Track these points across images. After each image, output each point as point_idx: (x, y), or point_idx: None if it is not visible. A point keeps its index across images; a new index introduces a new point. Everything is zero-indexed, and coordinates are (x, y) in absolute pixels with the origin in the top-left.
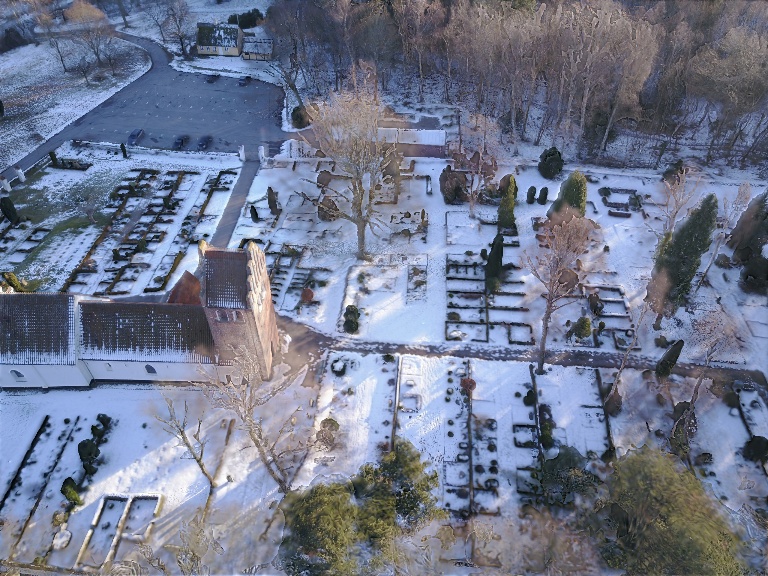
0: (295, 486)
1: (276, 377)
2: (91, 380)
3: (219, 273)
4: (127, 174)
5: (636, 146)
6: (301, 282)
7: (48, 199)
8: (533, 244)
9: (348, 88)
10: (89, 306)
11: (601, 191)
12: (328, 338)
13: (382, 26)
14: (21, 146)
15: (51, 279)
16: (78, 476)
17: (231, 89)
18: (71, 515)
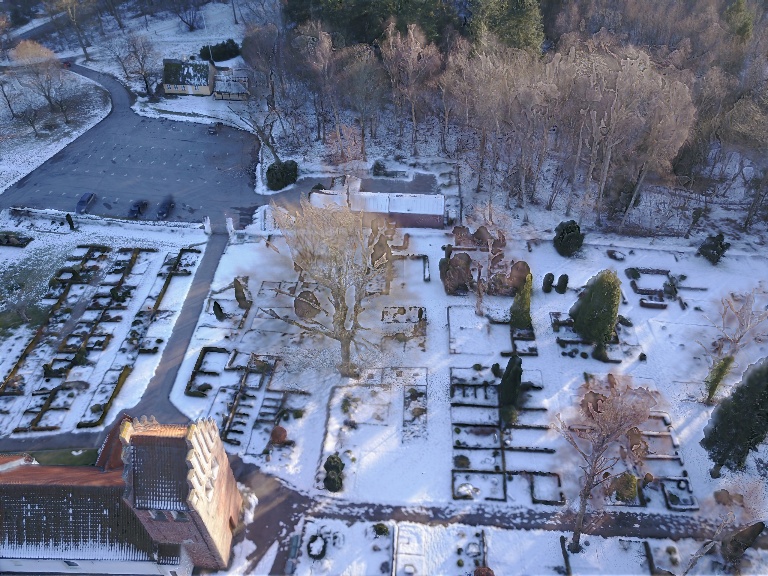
0: None
1: (237, 563)
2: None
3: (150, 464)
4: (73, 252)
5: (661, 206)
6: (272, 412)
7: None
8: (554, 351)
9: (332, 135)
10: None
11: (629, 272)
12: (304, 498)
13: (369, 73)
14: None
15: None
16: None
17: (199, 138)
18: None
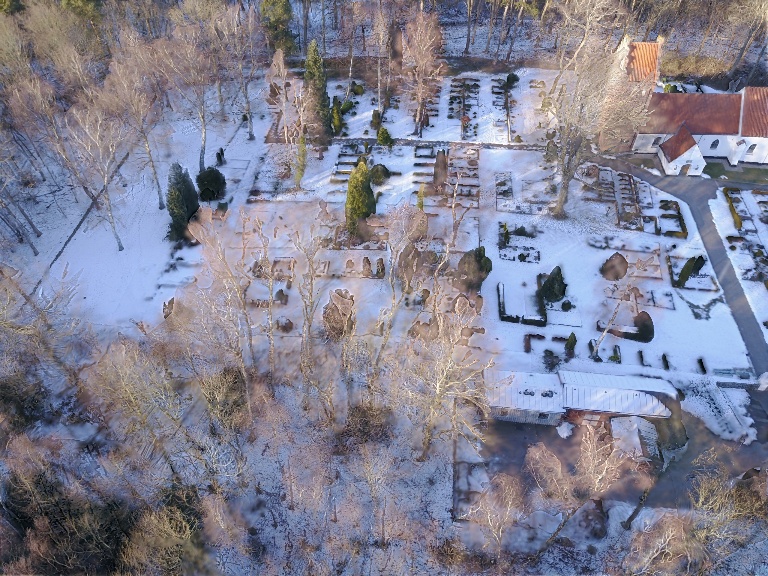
0: None
1: None
2: None
3: None
4: None
5: None
6: None
7: None
8: None
9: None
10: None
11: None
12: None
13: None
14: None
15: None
16: None
17: None
18: None
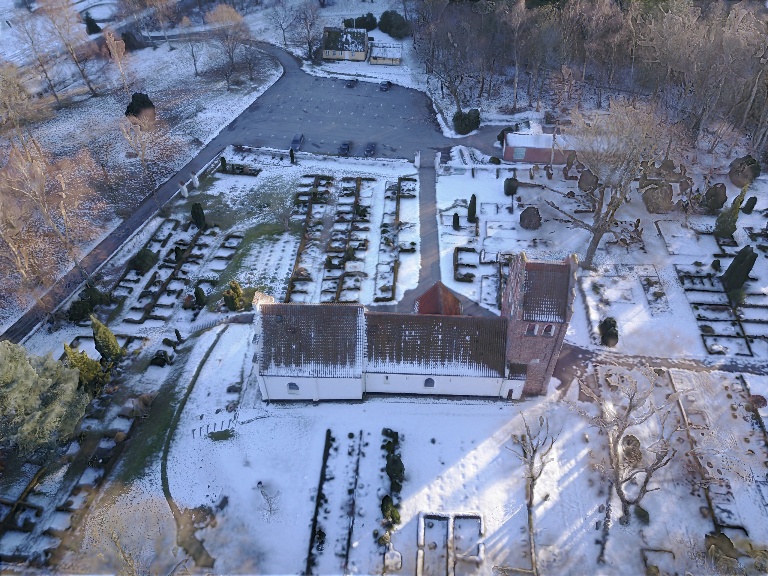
0: (614, 506)
1: (550, 391)
2: (362, 393)
3: (538, 286)
4: (300, 180)
5: None
6: None
7: (228, 205)
8: None
9: (491, 94)
10: (375, 318)
11: None
12: (586, 351)
13: None
14: (184, 151)
15: (267, 287)
16: (385, 493)
17: (374, 94)
18: (392, 534)
